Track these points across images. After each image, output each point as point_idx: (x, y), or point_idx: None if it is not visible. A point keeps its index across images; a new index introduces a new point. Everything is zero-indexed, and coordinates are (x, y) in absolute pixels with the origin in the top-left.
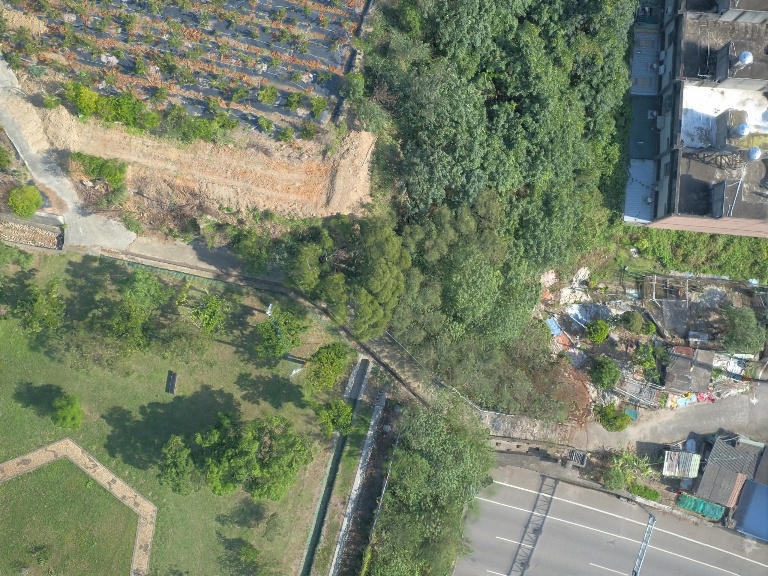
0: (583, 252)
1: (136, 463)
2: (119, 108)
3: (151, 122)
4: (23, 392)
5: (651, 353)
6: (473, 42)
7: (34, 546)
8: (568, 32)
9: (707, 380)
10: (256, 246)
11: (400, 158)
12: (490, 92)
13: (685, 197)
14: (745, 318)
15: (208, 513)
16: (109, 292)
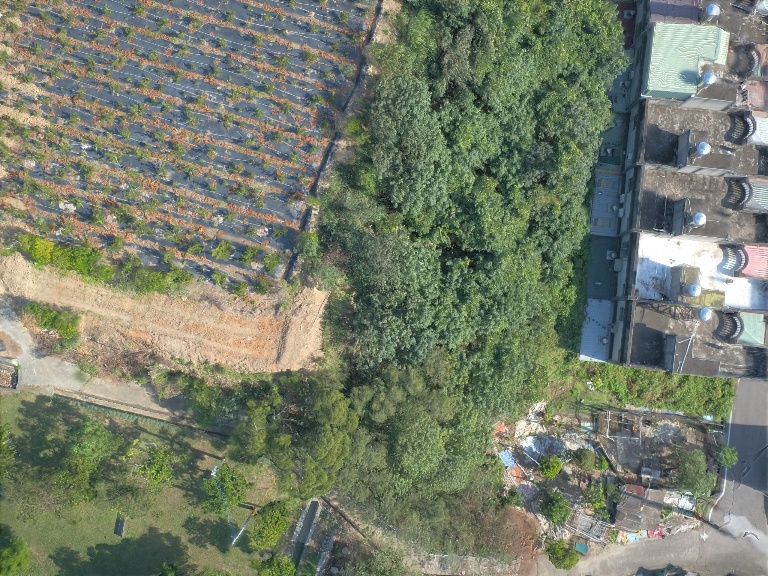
0: (533, 403)
1: None
2: (73, 261)
3: (105, 275)
4: None
5: (602, 492)
6: (428, 202)
7: None
8: (525, 185)
9: (657, 519)
10: (206, 399)
11: (353, 310)
12: (445, 245)
13: (638, 346)
14: (695, 463)
15: None
16: (61, 432)
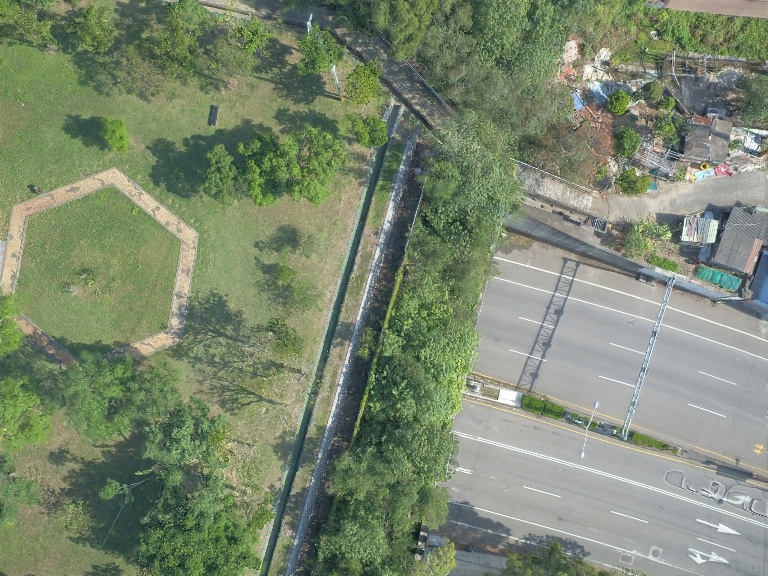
0: (607, 0)
1: (179, 191)
2: None
3: None
4: (73, 123)
5: None
6: None
7: (82, 268)
8: None
9: (725, 149)
10: None
11: None
12: None
13: None
14: (762, 82)
15: (247, 240)
16: (155, 31)
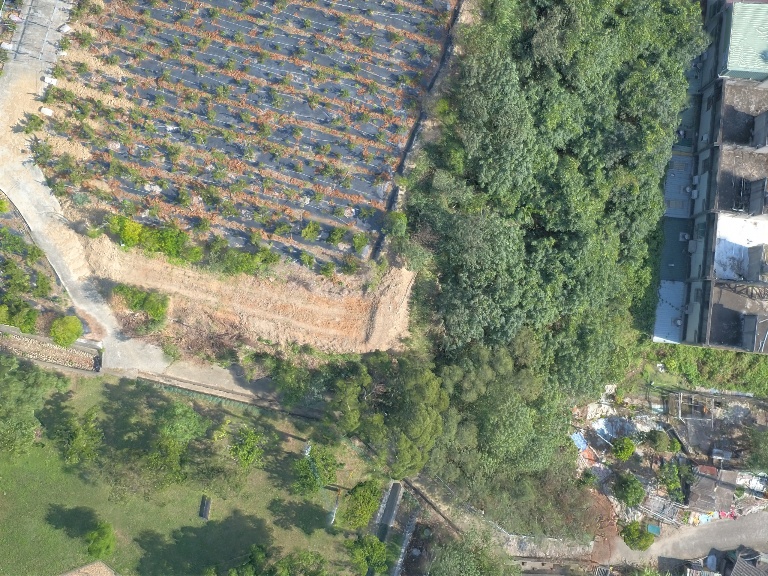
0: None
1: None
2: (163, 242)
3: (194, 256)
4: (57, 514)
5: (676, 474)
6: (515, 182)
7: None
8: (606, 166)
9: (730, 500)
10: (295, 380)
11: (438, 291)
12: (528, 225)
13: (716, 326)
14: None
15: None
16: (145, 415)
